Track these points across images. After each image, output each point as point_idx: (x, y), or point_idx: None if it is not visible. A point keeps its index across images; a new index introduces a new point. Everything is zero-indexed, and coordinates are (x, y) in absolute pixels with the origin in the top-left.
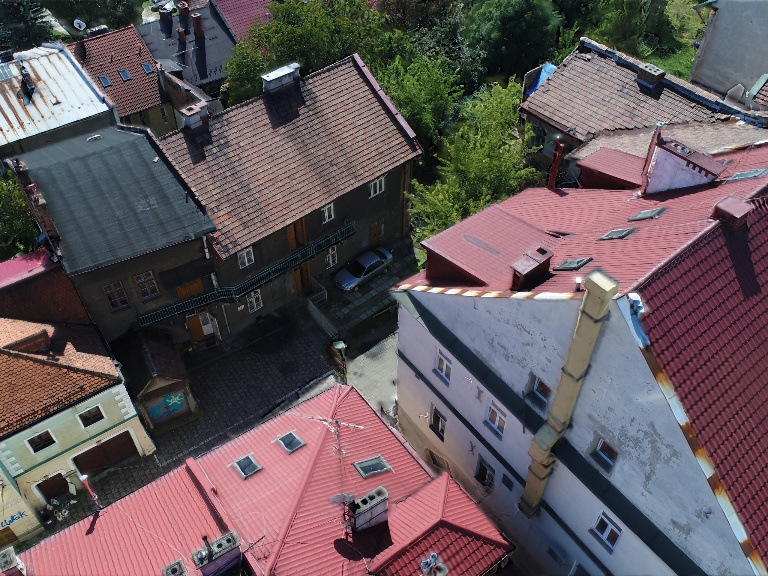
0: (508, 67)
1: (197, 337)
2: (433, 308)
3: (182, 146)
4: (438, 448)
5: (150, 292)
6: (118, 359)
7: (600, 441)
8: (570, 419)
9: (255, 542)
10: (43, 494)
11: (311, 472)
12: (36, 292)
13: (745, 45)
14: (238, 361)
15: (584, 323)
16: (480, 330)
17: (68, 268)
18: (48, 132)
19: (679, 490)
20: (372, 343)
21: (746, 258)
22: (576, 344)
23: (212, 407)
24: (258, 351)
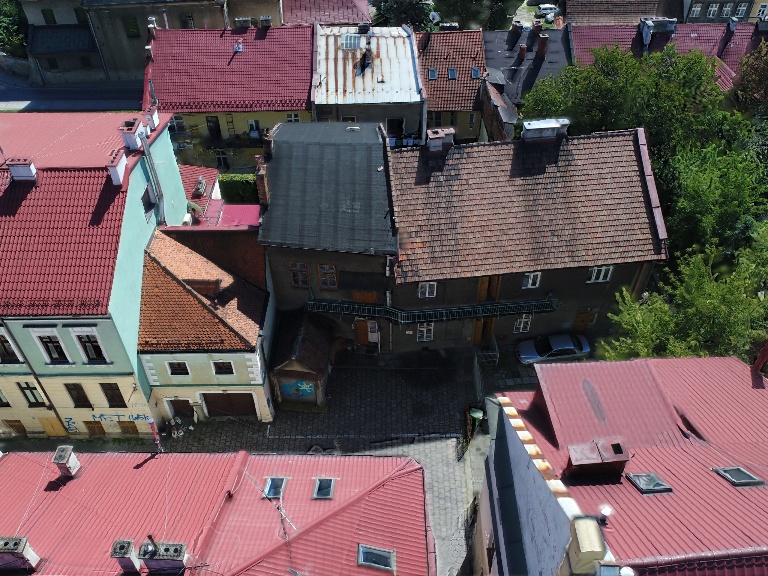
0: None
1: (361, 340)
2: (509, 439)
3: (413, 164)
4: (487, 575)
5: (329, 283)
6: (281, 328)
7: None
8: None
9: None
10: (174, 409)
11: (309, 529)
12: (234, 245)
13: None
14: (384, 379)
15: (565, 566)
16: (526, 492)
17: (261, 236)
18: (363, 104)
19: None
20: None
21: None
22: None
23: (337, 409)
24: (406, 379)
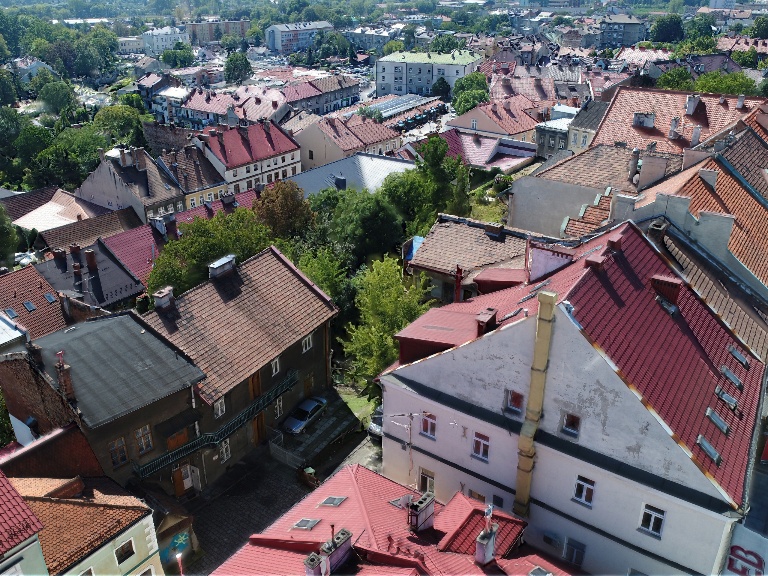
0: (372, 254)
1: (179, 492)
2: (417, 377)
3: (158, 322)
4: None
5: (145, 446)
6: None
7: (565, 419)
8: (542, 410)
9: (359, 536)
10: None
11: (365, 506)
12: (57, 451)
13: (538, 214)
14: (221, 505)
15: (542, 326)
16: (460, 375)
17: (89, 422)
18: None
19: (626, 420)
20: (333, 467)
21: (611, 287)
22: (539, 345)
23: (210, 546)
24: (236, 494)
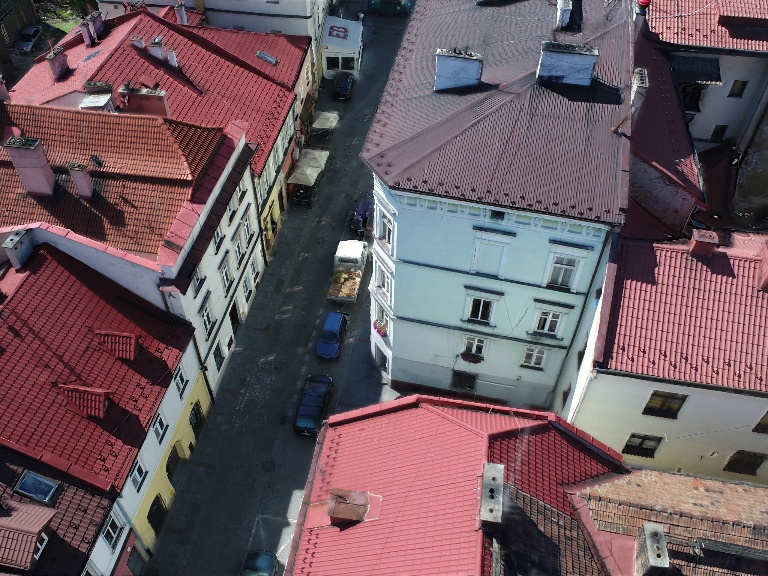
0: None
1: None
2: None
3: None
4: None
5: None
6: None
7: None
8: None
9: None
10: None
11: None
12: None
13: None
14: None
15: None
16: None
17: None
18: None
19: None
20: None
21: None
22: None
23: None
24: None
